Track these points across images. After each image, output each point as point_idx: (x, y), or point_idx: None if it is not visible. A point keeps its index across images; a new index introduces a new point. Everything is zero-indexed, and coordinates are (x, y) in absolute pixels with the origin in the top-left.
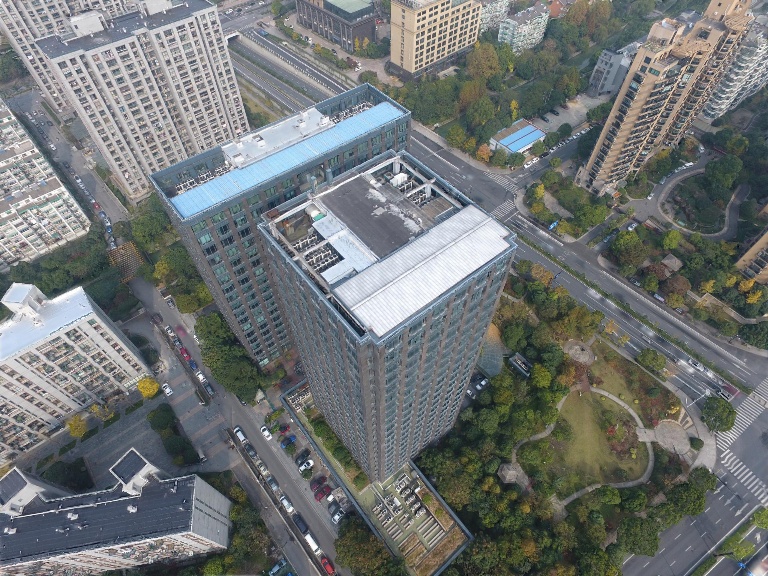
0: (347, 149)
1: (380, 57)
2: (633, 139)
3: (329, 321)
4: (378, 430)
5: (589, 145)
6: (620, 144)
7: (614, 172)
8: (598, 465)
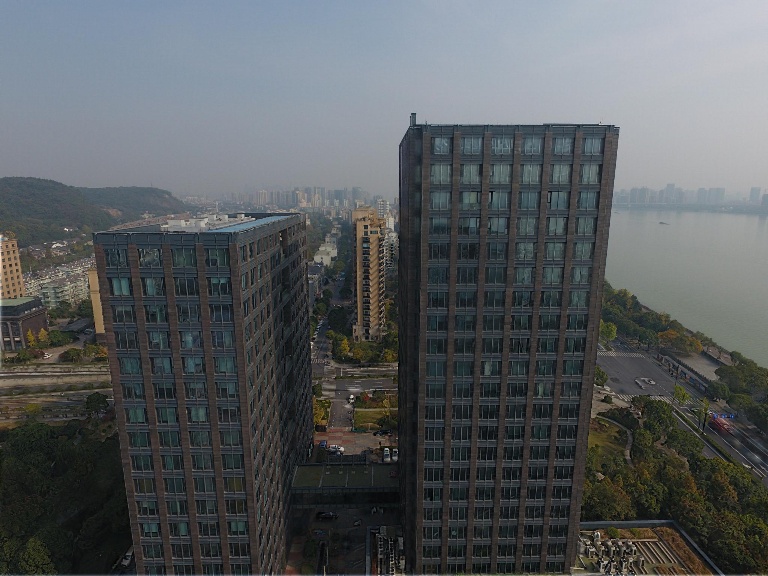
0: (292, 224)
1: (69, 343)
2: (381, 284)
3: (556, 157)
4: (593, 351)
5: (342, 316)
6: (375, 291)
7: (381, 314)
8: (607, 442)
